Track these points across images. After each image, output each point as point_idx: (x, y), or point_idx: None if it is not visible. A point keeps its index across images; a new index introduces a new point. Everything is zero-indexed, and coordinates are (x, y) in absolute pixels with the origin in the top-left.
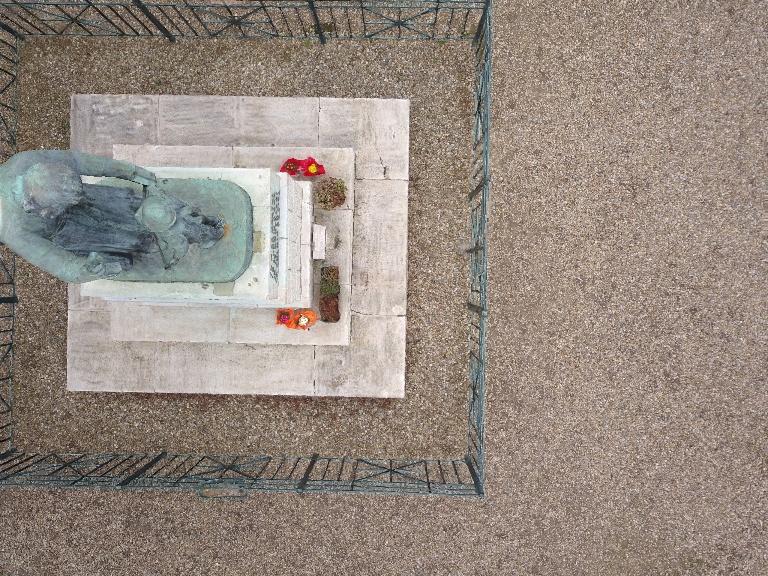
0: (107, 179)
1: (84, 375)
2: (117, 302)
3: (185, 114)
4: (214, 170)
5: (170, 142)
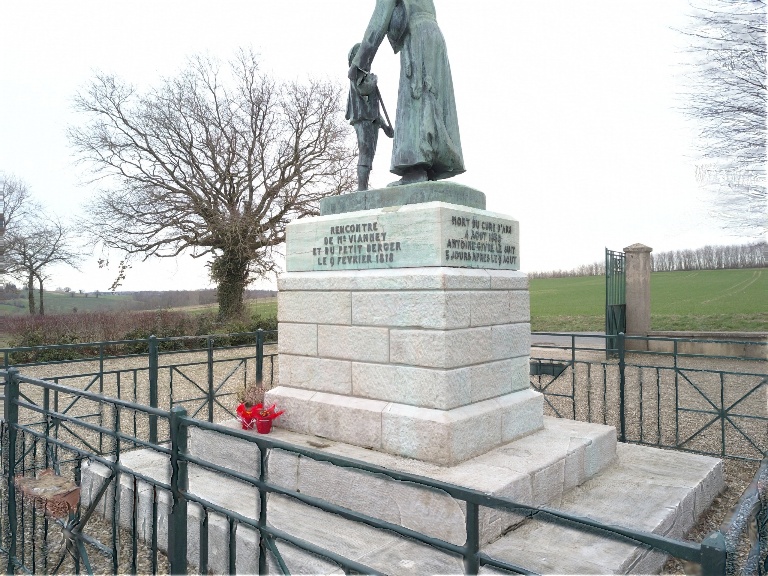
0: (416, 183)
1: (689, 458)
2: None
3: (318, 542)
4: (327, 216)
5: (381, 532)
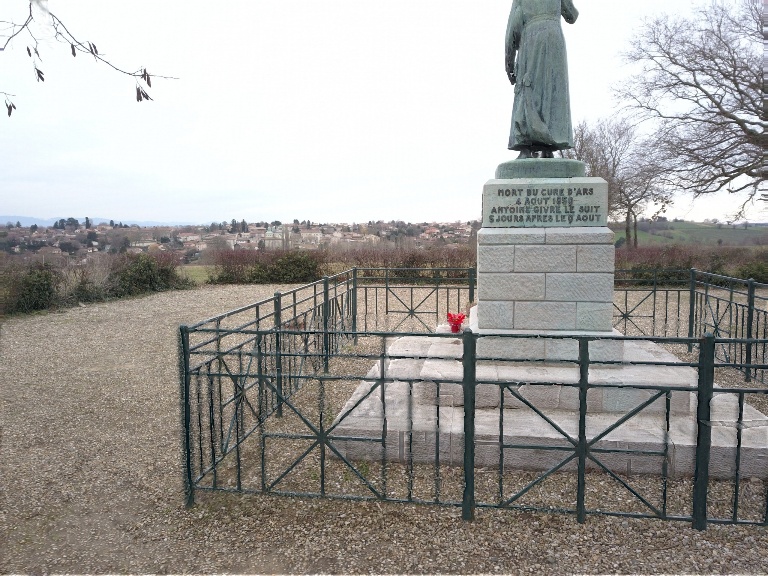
0: None
1: None
2: (632, 379)
3: None
4: None
5: None
